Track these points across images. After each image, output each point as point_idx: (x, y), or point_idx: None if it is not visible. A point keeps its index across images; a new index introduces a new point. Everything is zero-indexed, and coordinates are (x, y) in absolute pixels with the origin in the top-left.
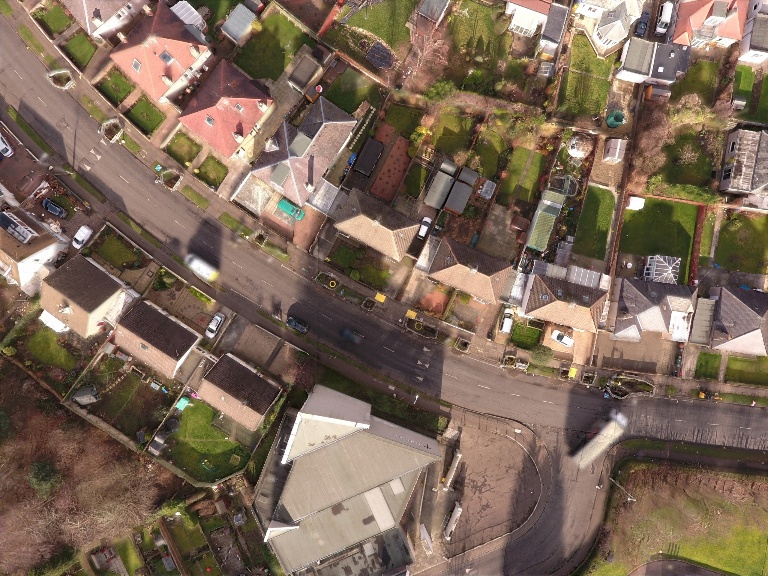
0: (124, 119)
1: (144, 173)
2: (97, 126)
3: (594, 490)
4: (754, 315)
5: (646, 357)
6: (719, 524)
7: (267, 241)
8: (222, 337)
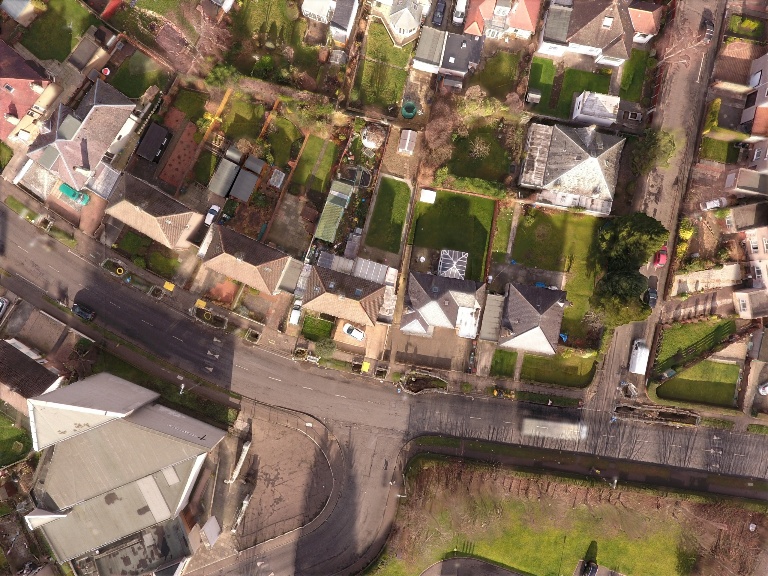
0: None
1: None
2: None
3: (387, 486)
4: (535, 312)
5: (441, 353)
6: (515, 523)
7: (53, 226)
8: (7, 322)
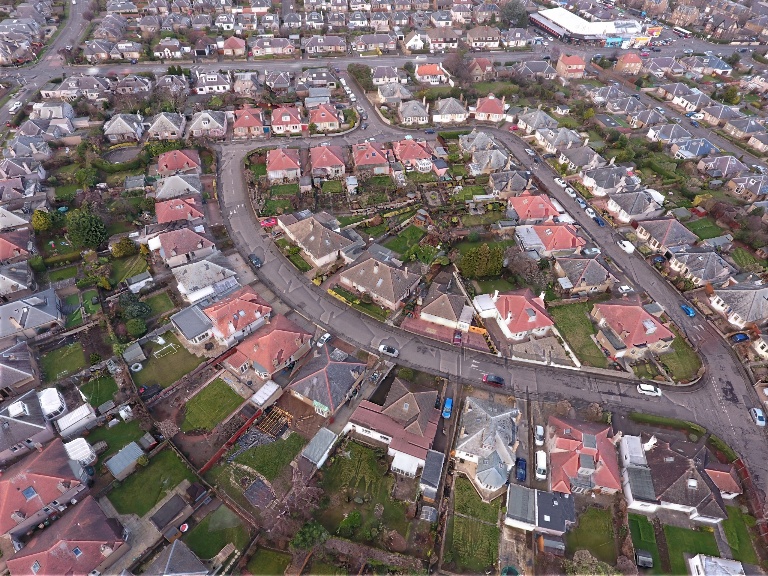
0: None
1: None
2: None
3: None
4: None
5: None
6: None
7: None
8: None
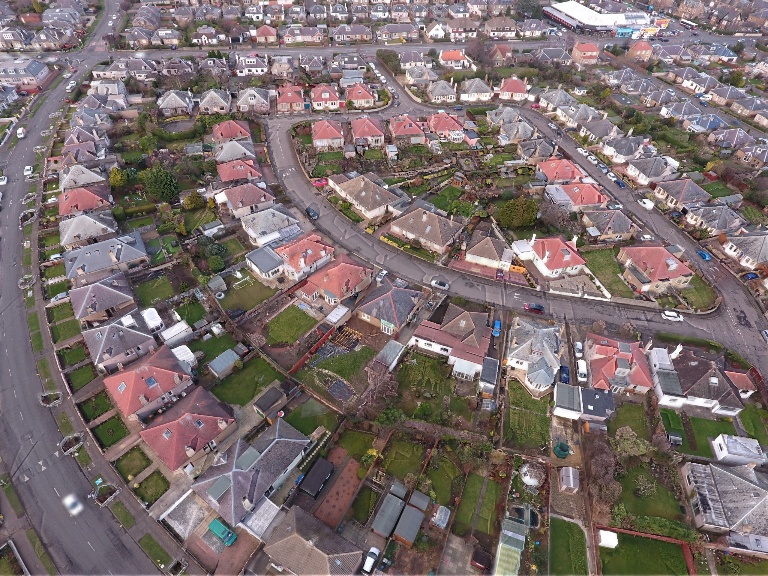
0: (89, 434)
1: (81, 486)
2: (60, 439)
3: None
4: None
5: None
6: None
7: (184, 572)
8: None
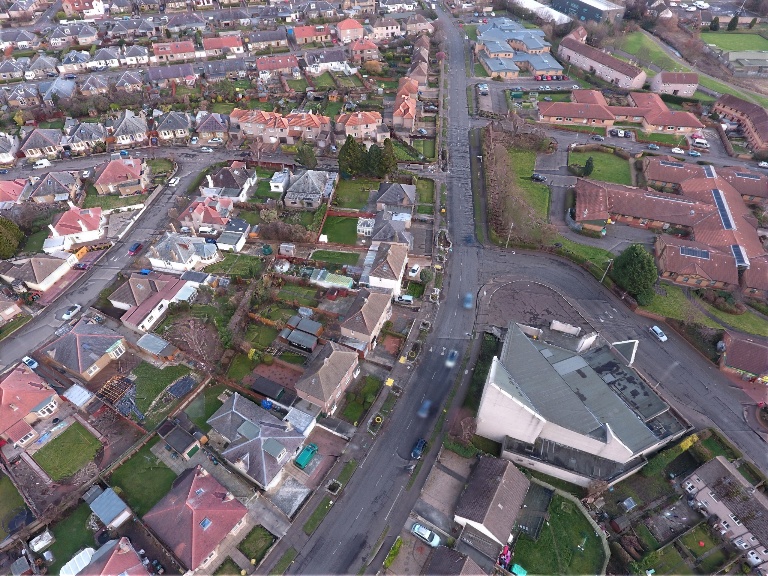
0: None
1: None
2: None
3: (517, 255)
4: (392, 187)
5: (423, 234)
6: None
7: None
8: None
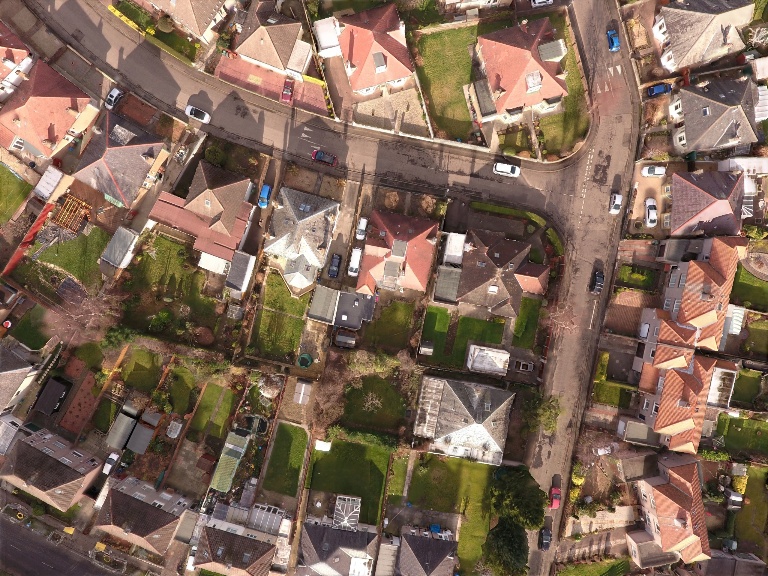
0: None
1: None
2: None
3: None
4: (422, 572)
5: None
6: None
7: None
8: None
